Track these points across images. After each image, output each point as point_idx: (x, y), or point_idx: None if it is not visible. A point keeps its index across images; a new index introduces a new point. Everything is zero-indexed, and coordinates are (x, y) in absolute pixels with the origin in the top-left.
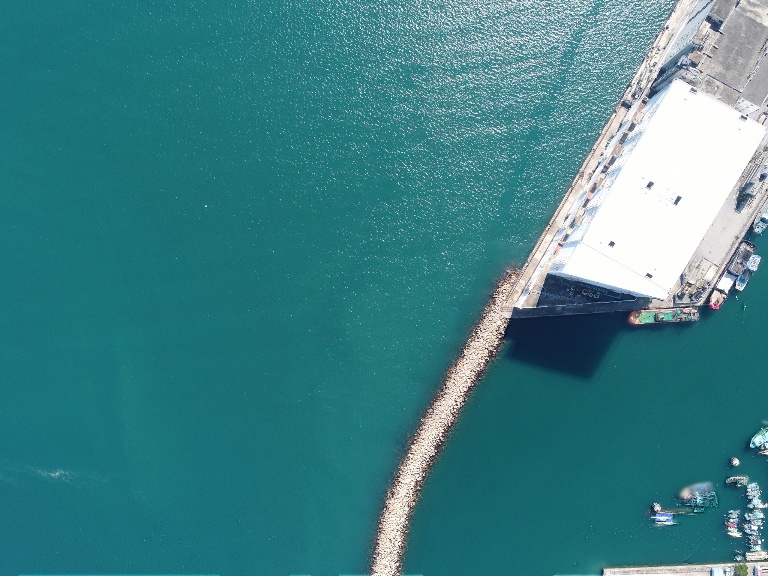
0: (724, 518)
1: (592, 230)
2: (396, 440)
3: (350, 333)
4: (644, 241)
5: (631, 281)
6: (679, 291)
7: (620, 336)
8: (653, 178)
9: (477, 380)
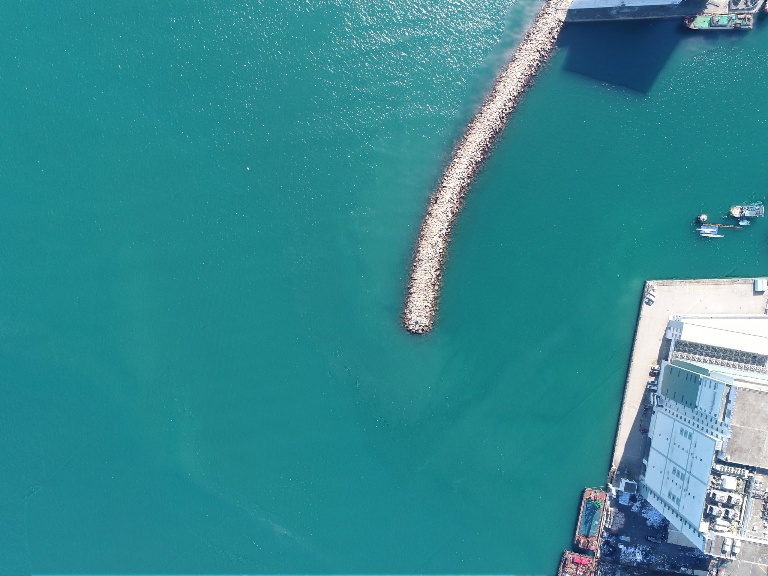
0: None
1: None
2: (442, 146)
3: None
4: None
5: None
6: None
7: (673, 45)
8: None
9: (527, 86)
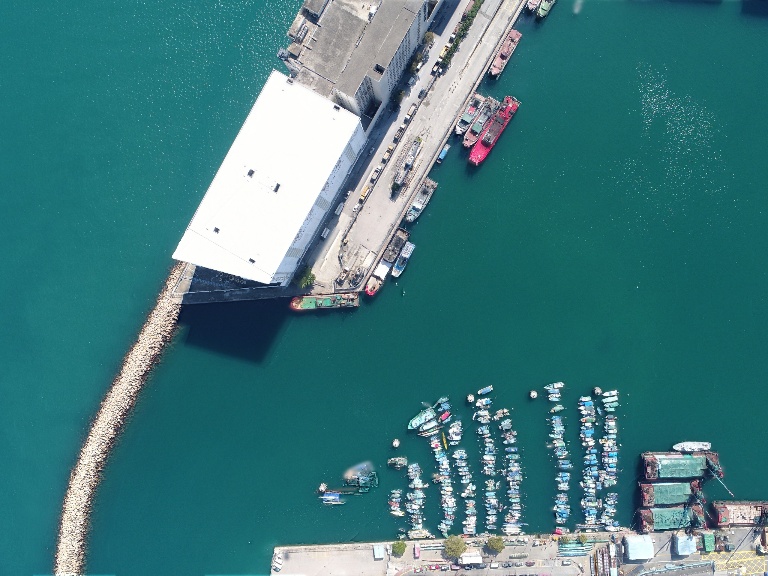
0: (388, 498)
1: (199, 217)
2: (79, 423)
3: (31, 319)
4: (246, 227)
5: (236, 266)
6: (337, 277)
7: (288, 321)
8: (254, 166)
9: (154, 364)
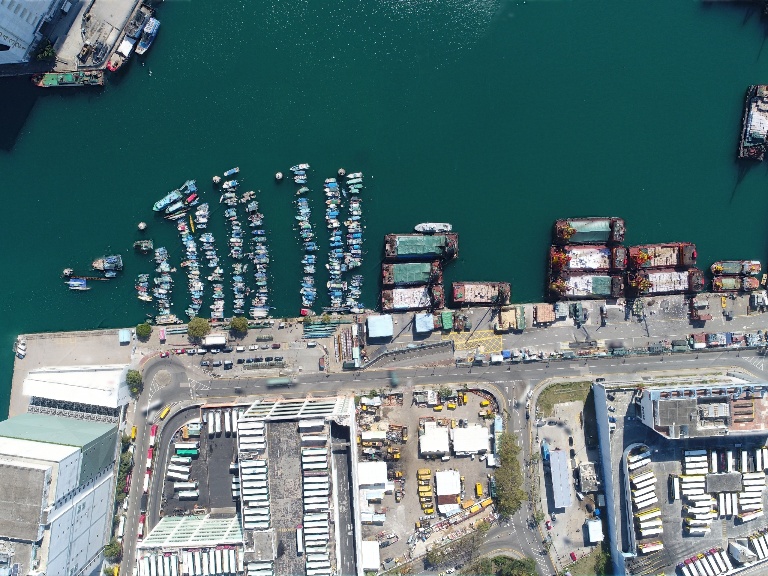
0: (135, 283)
1: None
2: None
3: None
4: None
5: None
6: (79, 53)
7: (32, 102)
8: None
9: None
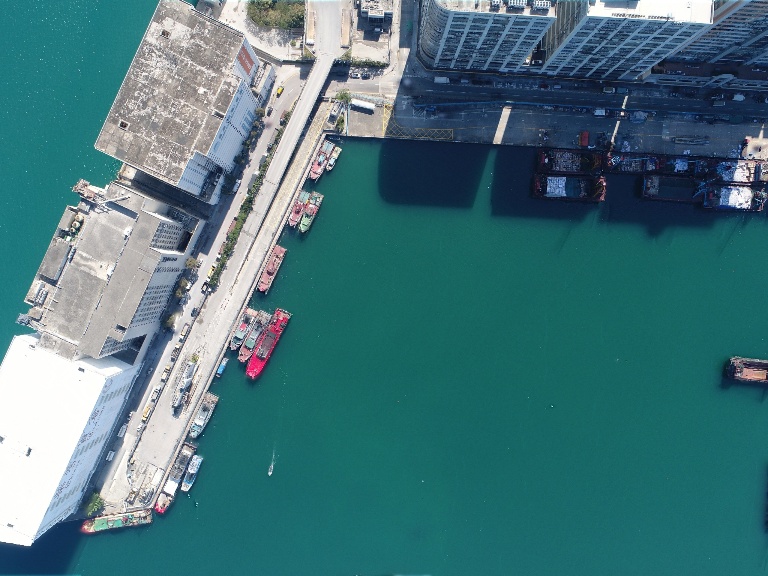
0: None
1: None
2: None
3: None
4: (1, 493)
5: None
6: (127, 498)
7: (84, 542)
8: (4, 432)
9: None
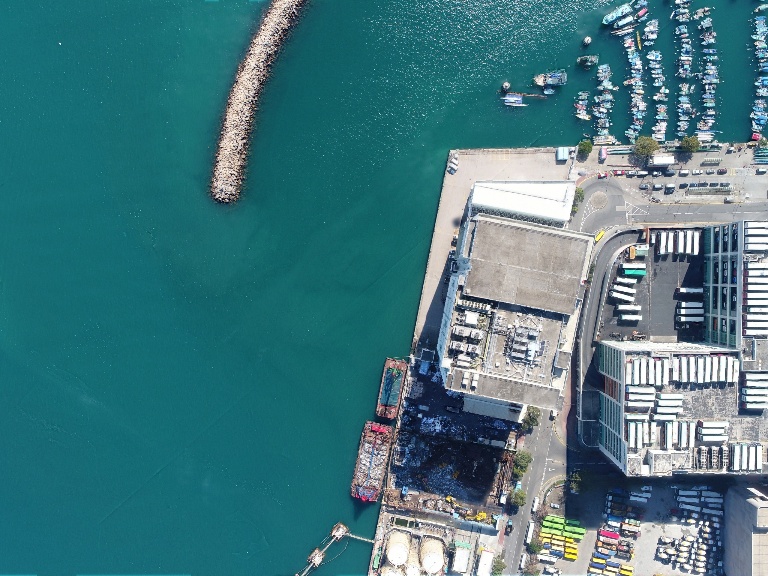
0: (574, 101)
1: None
2: (250, 15)
3: None
4: None
5: None
6: None
7: None
8: None
9: None
